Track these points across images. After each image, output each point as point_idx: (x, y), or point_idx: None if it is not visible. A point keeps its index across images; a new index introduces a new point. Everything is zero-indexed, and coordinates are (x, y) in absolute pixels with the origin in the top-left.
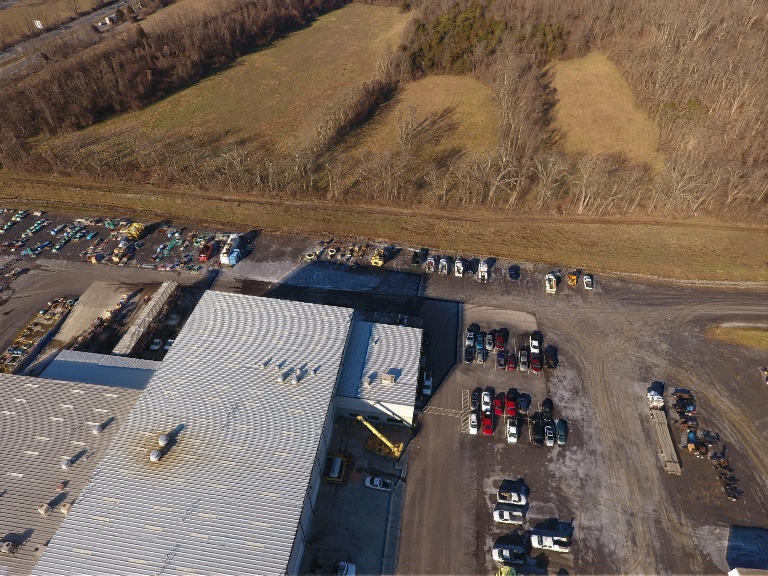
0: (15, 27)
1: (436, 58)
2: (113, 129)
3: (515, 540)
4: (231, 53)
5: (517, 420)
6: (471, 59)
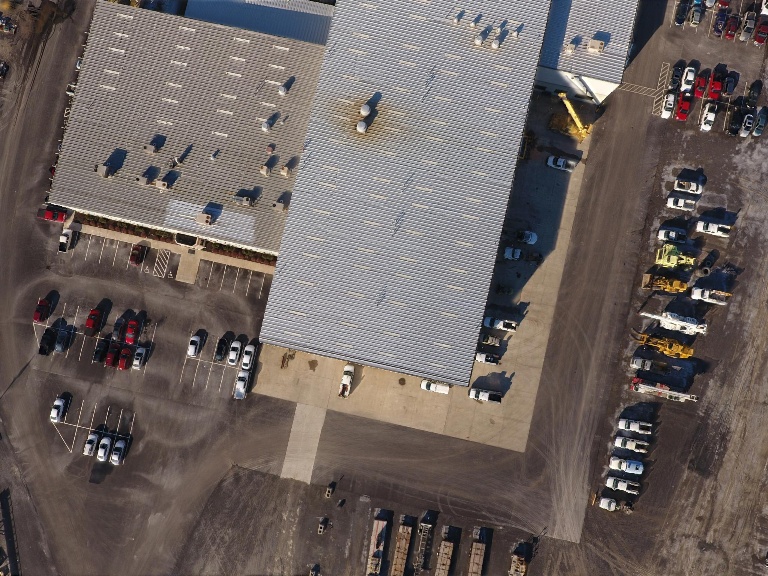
0: None
1: None
2: None
3: (680, 224)
4: None
5: (716, 104)
6: None
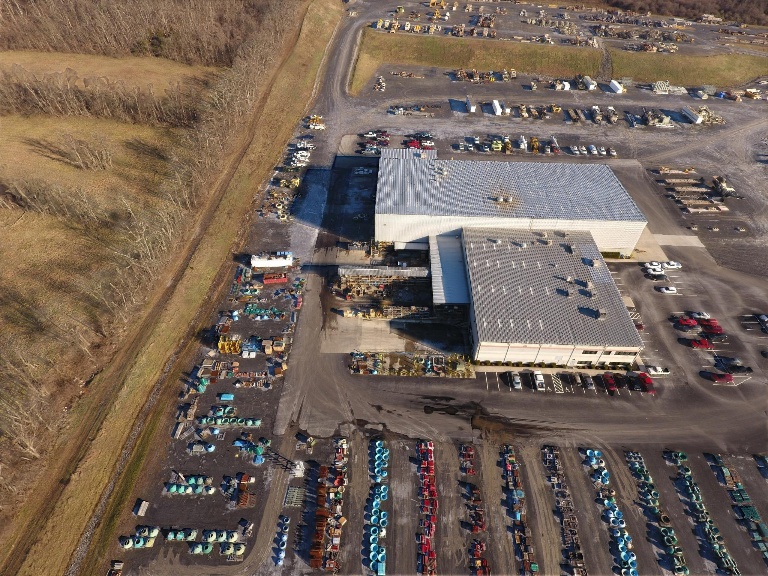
0: None
1: None
2: None
3: None
4: None
5: None
6: None
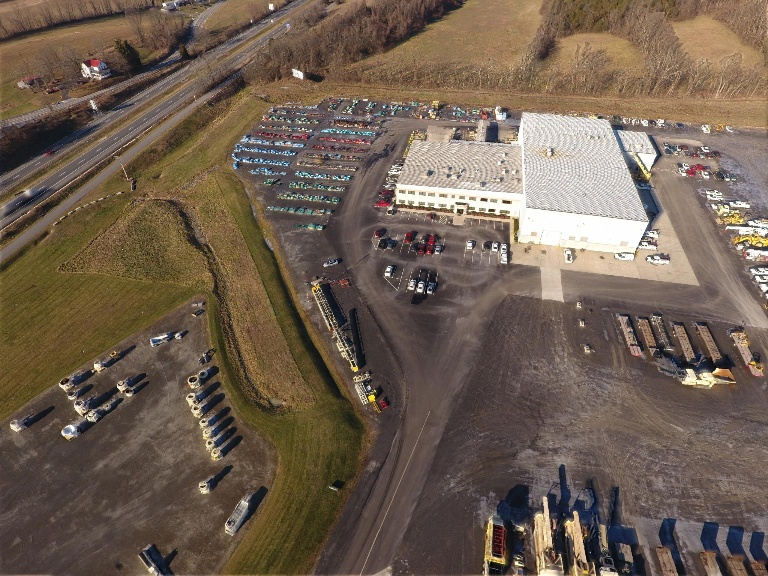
0: (260, 8)
1: (580, 21)
2: (376, 62)
3: None
4: (422, 22)
5: None
6: (609, 20)
